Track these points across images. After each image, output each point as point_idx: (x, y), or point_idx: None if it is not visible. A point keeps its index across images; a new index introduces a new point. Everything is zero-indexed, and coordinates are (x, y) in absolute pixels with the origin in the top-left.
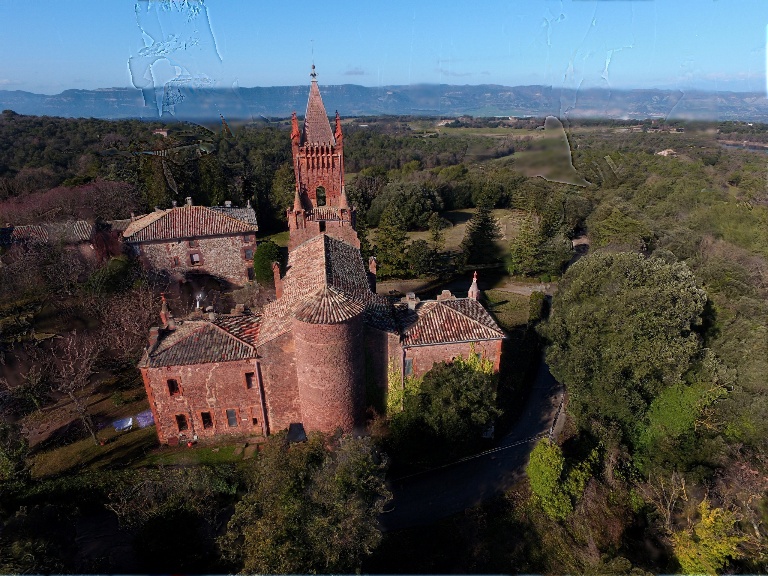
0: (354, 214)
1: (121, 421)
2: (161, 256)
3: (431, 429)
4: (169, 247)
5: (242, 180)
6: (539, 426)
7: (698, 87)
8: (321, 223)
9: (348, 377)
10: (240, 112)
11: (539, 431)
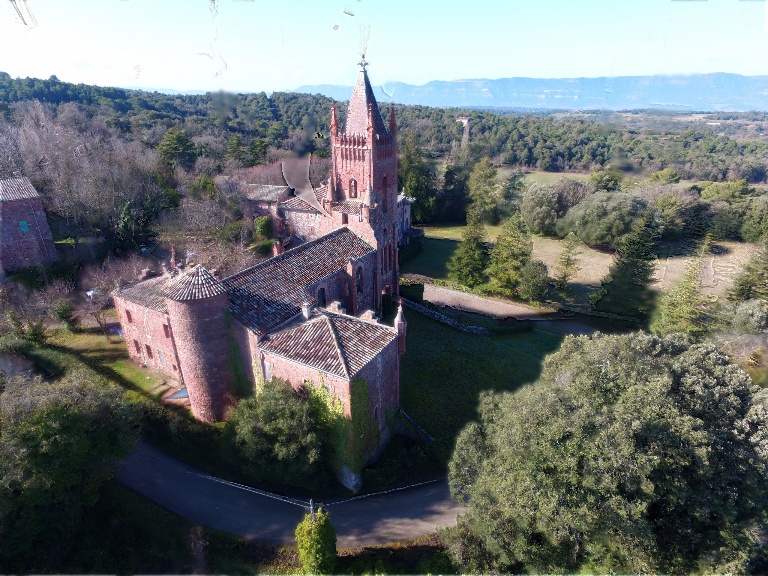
0: (375, 211)
1: None
2: (303, 223)
3: (234, 437)
4: (309, 217)
5: (446, 169)
6: (419, 512)
7: None
8: (345, 215)
9: (198, 355)
10: None
11: (410, 516)
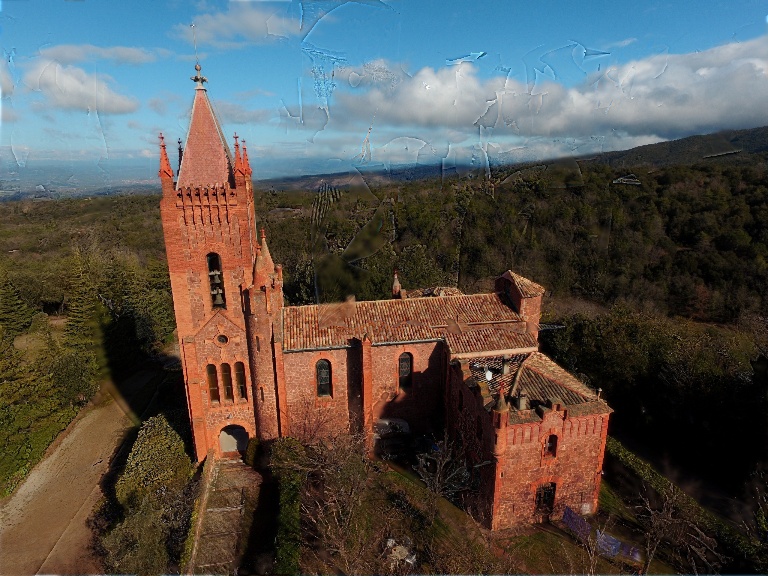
0: None
1: None
2: None
3: None
4: None
5: None
6: None
7: (177, 143)
8: None
9: None
10: None
11: None
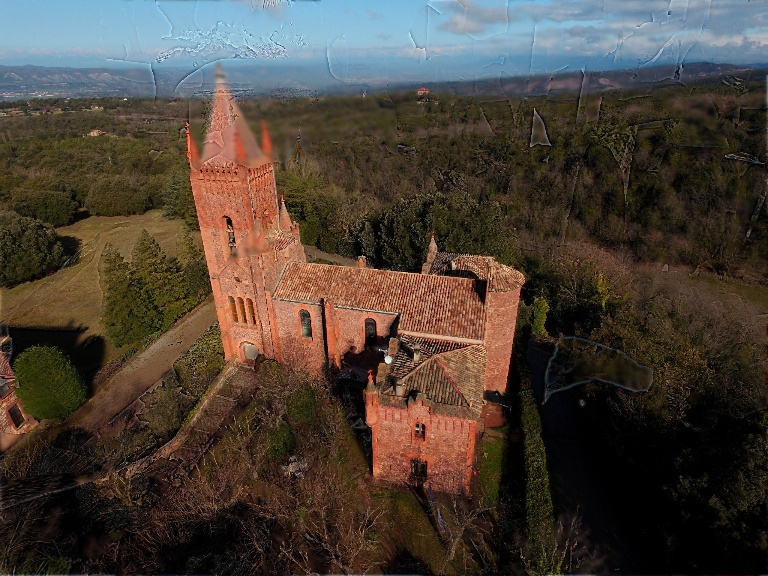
0: None
1: (410, 540)
2: None
3: (529, 325)
4: None
5: None
6: None
7: None
8: None
9: None
10: (323, 129)
11: None
